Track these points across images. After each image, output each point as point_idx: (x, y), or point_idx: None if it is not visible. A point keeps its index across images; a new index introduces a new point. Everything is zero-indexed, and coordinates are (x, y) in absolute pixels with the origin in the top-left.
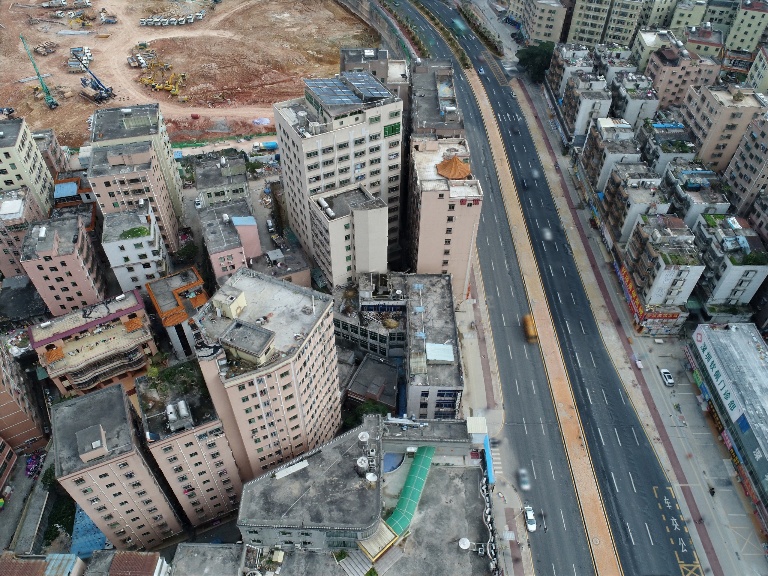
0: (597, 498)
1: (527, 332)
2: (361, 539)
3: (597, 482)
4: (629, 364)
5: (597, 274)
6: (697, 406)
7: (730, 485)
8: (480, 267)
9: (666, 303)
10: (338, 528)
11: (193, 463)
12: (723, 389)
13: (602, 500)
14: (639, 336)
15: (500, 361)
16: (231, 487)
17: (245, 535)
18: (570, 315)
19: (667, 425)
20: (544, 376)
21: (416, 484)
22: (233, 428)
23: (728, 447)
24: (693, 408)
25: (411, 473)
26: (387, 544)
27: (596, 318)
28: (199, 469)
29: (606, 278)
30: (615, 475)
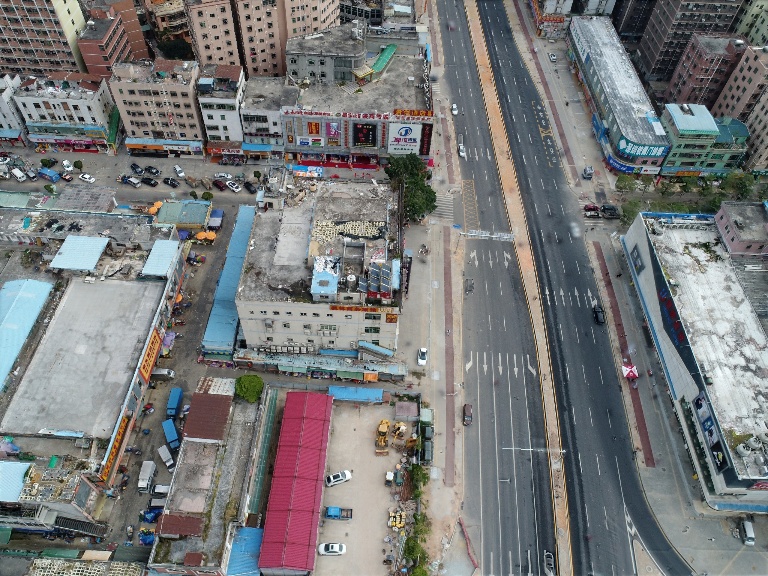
0: (496, 103)
1: (464, 34)
2: (353, 68)
3: (498, 98)
4: (529, 51)
5: (517, 8)
6: (569, 71)
7: (579, 102)
8: (436, 2)
9: (556, 11)
10: (341, 55)
11: (258, 28)
12: (581, 46)
13: (499, 105)
14: (539, 38)
15: (444, 47)
16: (276, 64)
17: (288, 65)
18: (495, 27)
19: (547, 77)
20: (473, 54)
21: (385, 57)
22: (281, 8)
23: (580, 80)
24: (566, 72)
25: (382, 53)
26: (368, 72)
27: (512, 29)
28: (260, 36)
29: (523, 11)
30: (510, 95)
